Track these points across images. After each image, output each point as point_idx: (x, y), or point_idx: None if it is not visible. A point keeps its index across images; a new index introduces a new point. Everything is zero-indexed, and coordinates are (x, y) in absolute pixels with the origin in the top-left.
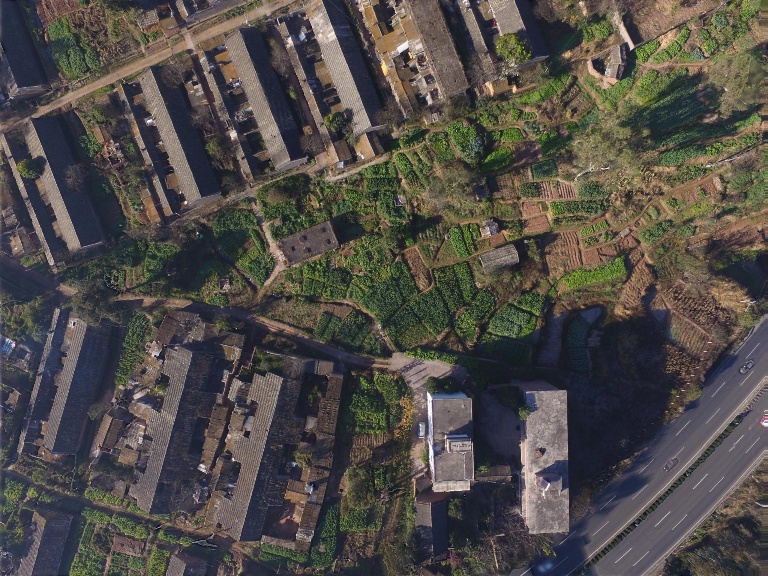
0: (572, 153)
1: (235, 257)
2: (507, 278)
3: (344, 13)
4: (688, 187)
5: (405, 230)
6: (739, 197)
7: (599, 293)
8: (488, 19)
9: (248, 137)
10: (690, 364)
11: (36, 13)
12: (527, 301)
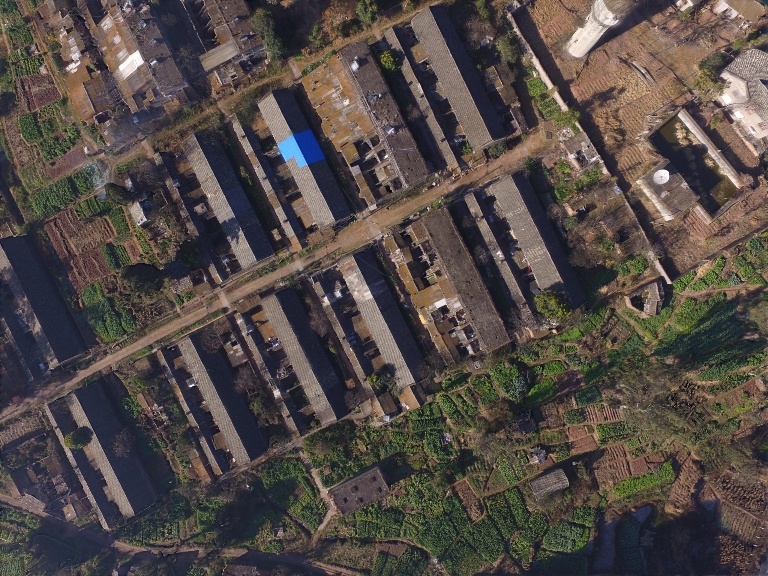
0: (615, 378)
1: (287, 505)
2: (558, 501)
3: (378, 269)
4: (731, 391)
5: (454, 466)
6: None
7: (648, 494)
8: (523, 268)
9: (291, 392)
10: (744, 552)
11: (68, 279)
12: (579, 516)
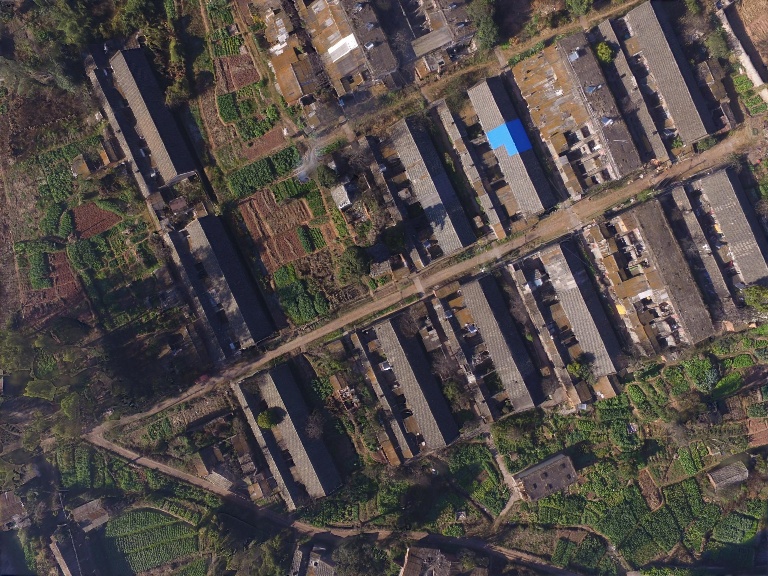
0: None
1: (471, 490)
2: None
3: (580, 258)
4: None
5: (637, 455)
6: None
7: None
8: (727, 261)
9: (484, 378)
10: None
11: (260, 260)
12: (749, 507)
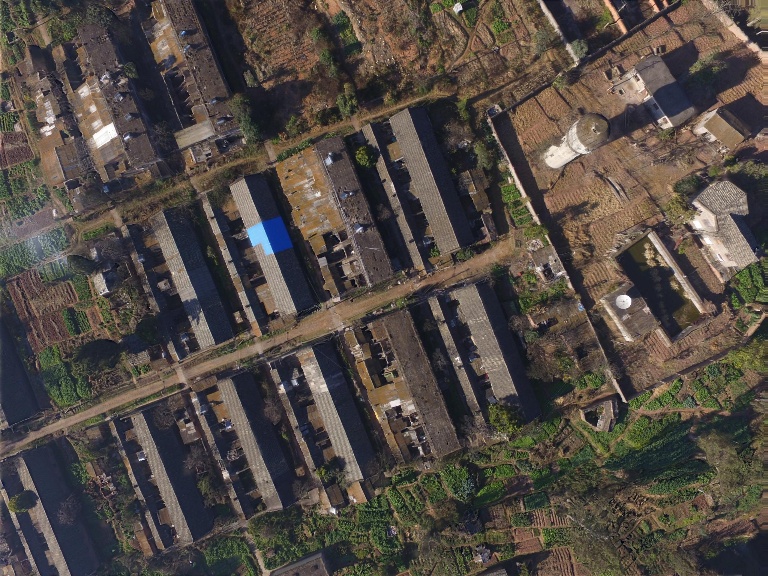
0: (564, 486)
1: None
2: None
3: (336, 361)
4: None
5: (397, 558)
6: (731, 507)
7: None
8: (481, 374)
9: (240, 474)
10: None
11: (27, 339)
12: None
